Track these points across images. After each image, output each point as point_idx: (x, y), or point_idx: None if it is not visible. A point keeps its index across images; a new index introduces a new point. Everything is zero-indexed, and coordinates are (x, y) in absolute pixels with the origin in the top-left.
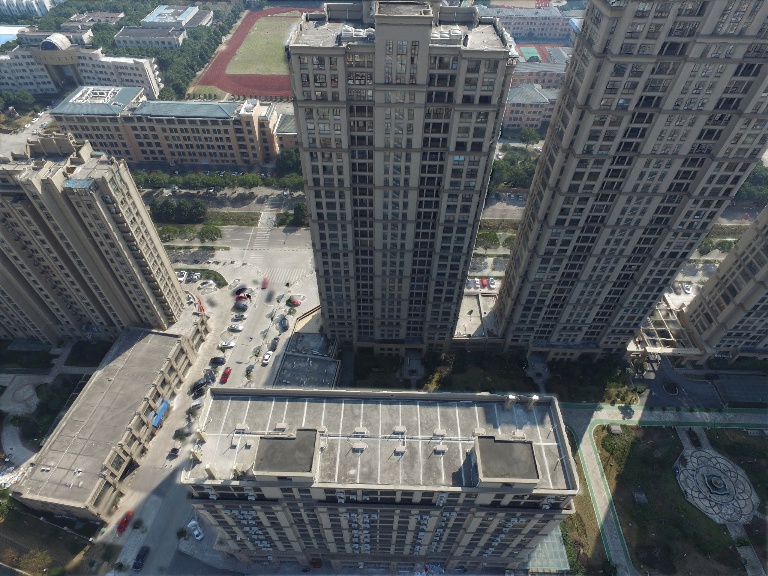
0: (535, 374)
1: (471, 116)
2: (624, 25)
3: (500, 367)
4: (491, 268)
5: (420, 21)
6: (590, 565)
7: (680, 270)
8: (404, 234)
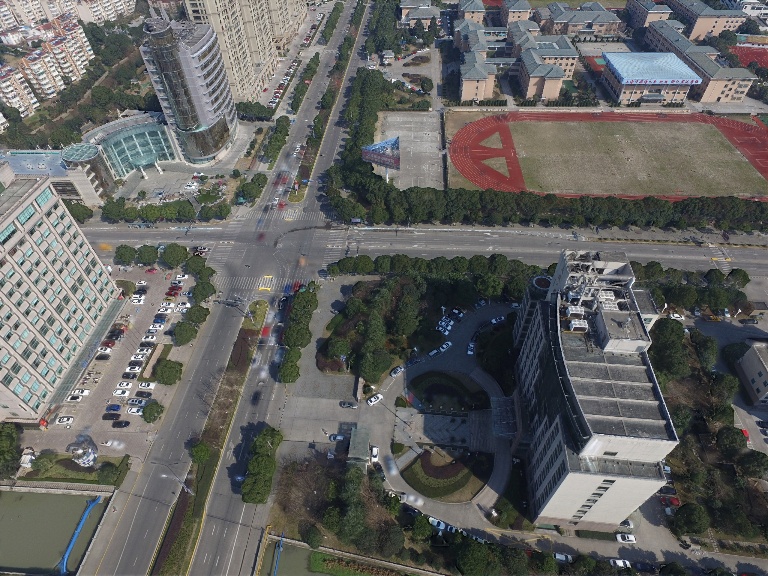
0: None
1: None
2: None
3: None
4: None
5: None
6: None
7: None
8: None
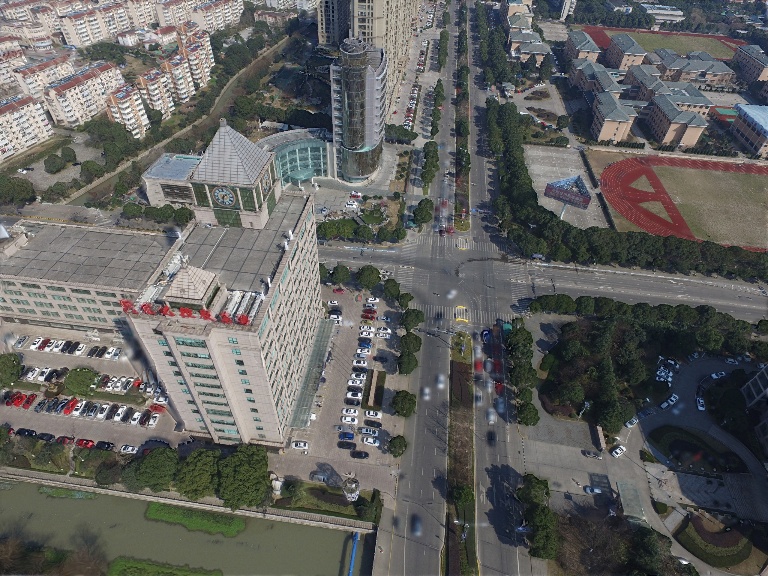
0: None
1: None
2: None
3: None
4: None
5: None
6: (316, 52)
7: None
8: None
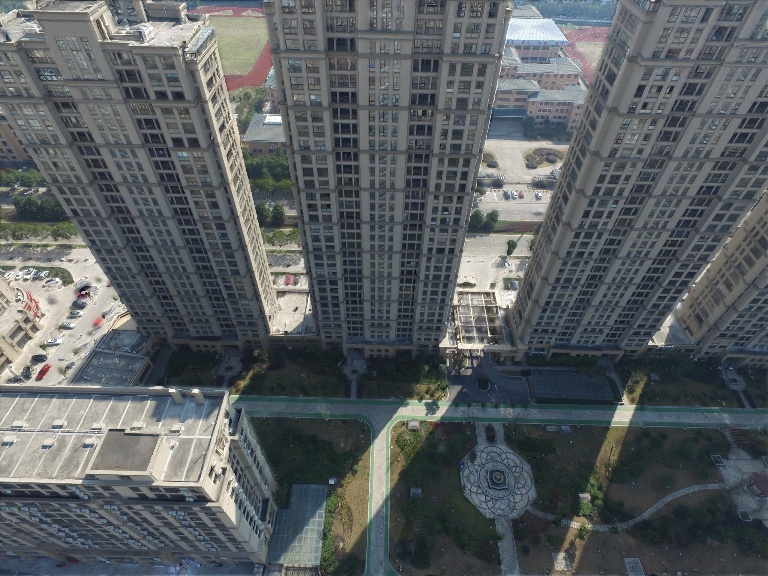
0: (351, 371)
1: (173, 112)
2: (277, 21)
3: (317, 364)
4: None
5: (77, 17)
6: (345, 559)
7: (455, 266)
8: (168, 230)
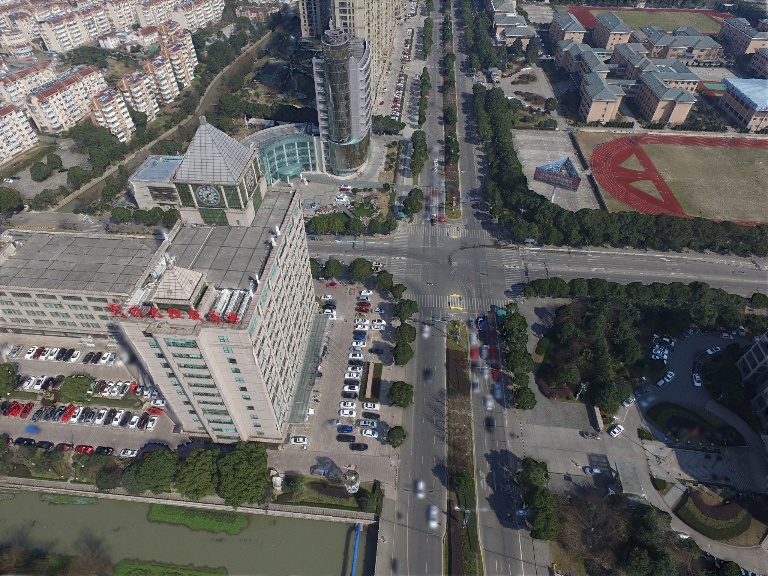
0: None
1: None
2: None
3: None
4: (417, 50)
5: None
6: None
7: None
8: None
